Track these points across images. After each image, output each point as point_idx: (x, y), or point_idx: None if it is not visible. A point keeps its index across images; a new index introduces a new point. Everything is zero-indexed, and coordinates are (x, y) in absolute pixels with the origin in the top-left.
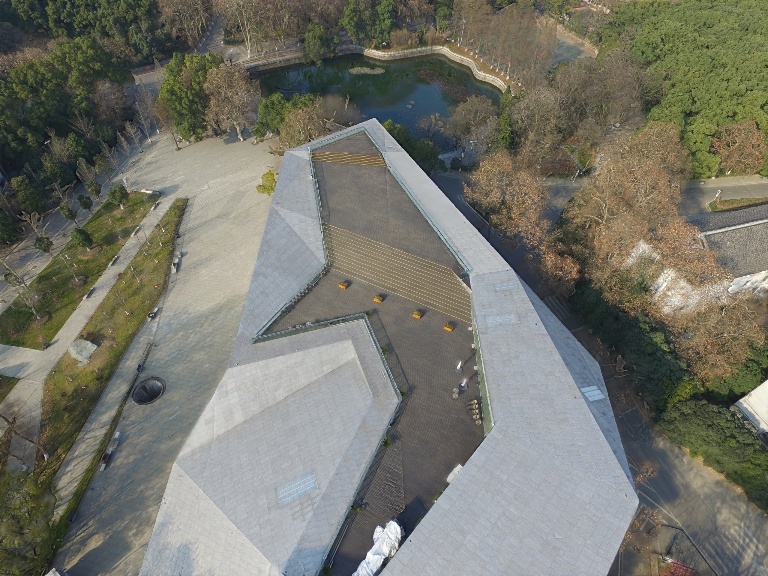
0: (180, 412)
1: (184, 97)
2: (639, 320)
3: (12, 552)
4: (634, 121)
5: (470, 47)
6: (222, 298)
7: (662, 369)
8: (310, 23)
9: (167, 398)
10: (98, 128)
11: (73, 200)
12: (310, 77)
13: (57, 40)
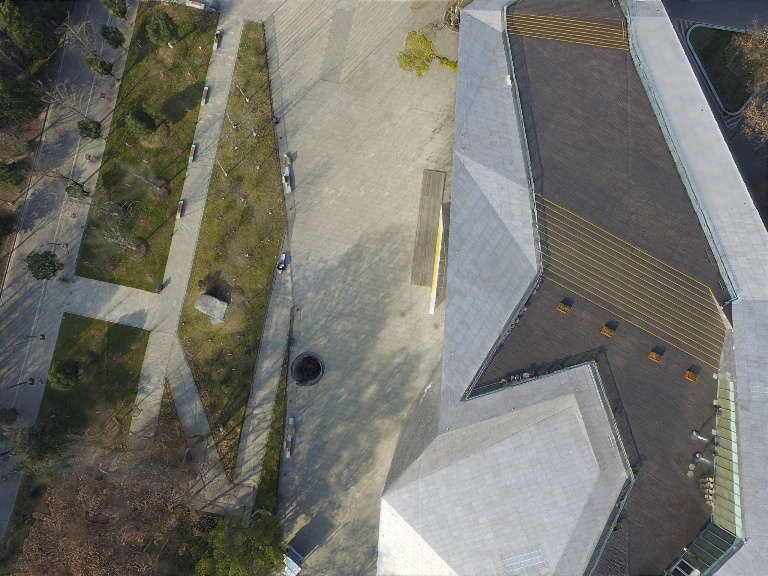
0: (347, 395)
1: None
2: None
3: None
4: None
5: None
6: (360, 237)
7: None
8: None
9: (329, 378)
10: None
11: (95, 35)
12: None
13: None
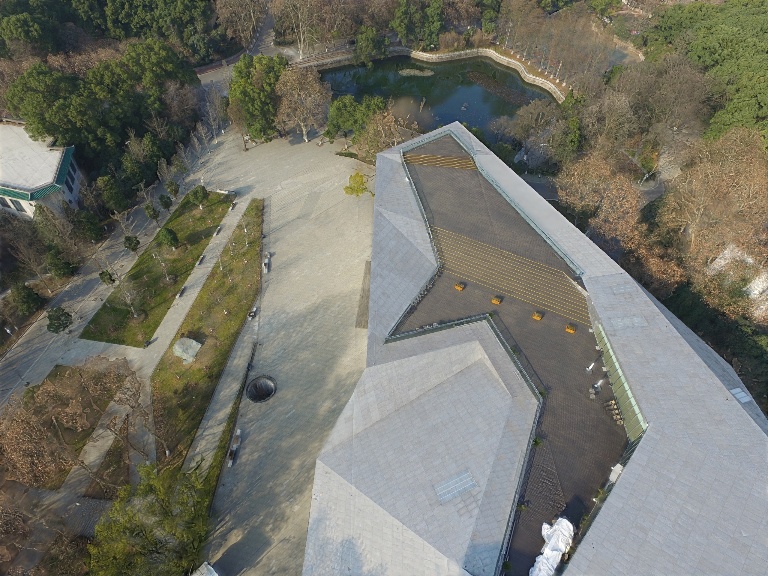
0: (295, 410)
1: (257, 98)
2: (739, 323)
3: (178, 545)
4: (690, 125)
5: (515, 50)
6: (317, 298)
7: None
8: (362, 25)
9: (280, 396)
10: (169, 128)
11: (154, 200)
12: (358, 78)
13: (128, 41)
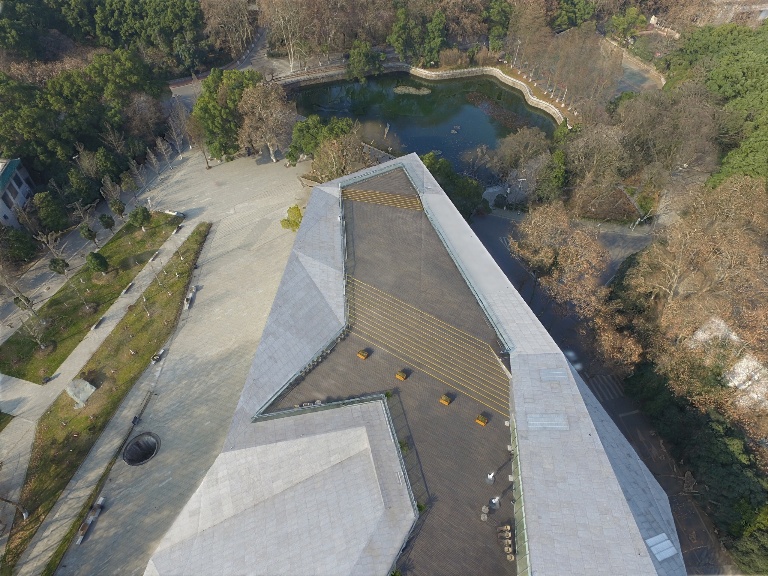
0: (172, 478)
1: (217, 116)
2: (711, 418)
3: None
4: (704, 162)
5: (524, 69)
6: (233, 343)
7: (740, 488)
8: (356, 39)
9: (160, 460)
10: (130, 142)
11: (95, 219)
12: (352, 94)
13: (97, 51)
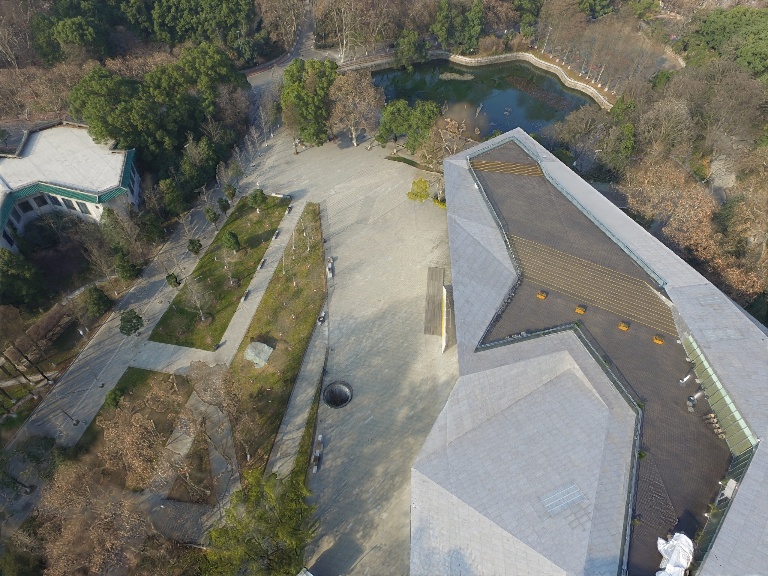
0: (373, 416)
1: (310, 103)
2: None
3: (285, 552)
4: (738, 131)
5: (554, 54)
6: (383, 304)
7: None
8: (404, 29)
9: (357, 402)
10: None
11: (213, 203)
12: (397, 82)
13: (182, 45)
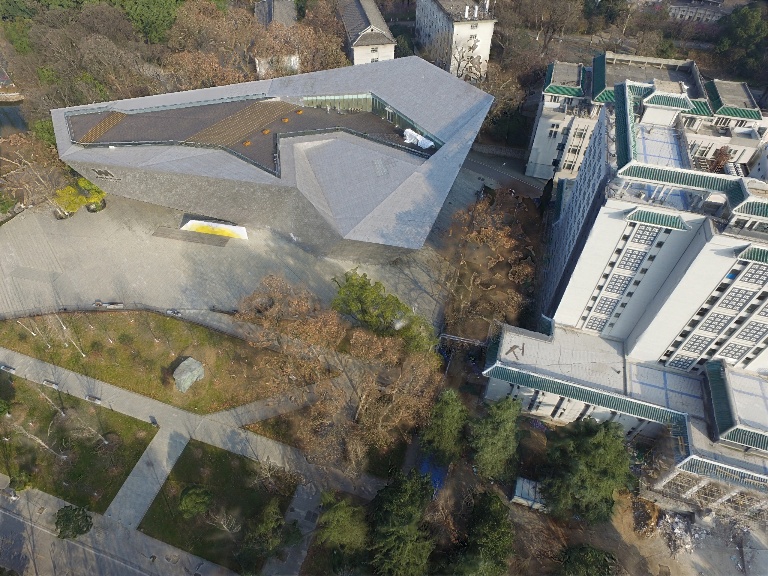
0: None
1: None
2: None
3: None
4: None
5: None
6: (179, 269)
7: None
8: None
9: None
10: None
11: None
12: None
13: None
